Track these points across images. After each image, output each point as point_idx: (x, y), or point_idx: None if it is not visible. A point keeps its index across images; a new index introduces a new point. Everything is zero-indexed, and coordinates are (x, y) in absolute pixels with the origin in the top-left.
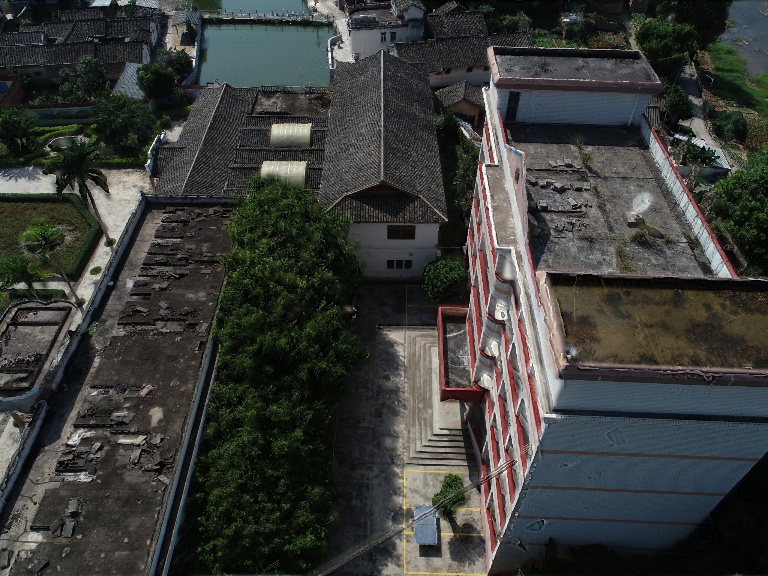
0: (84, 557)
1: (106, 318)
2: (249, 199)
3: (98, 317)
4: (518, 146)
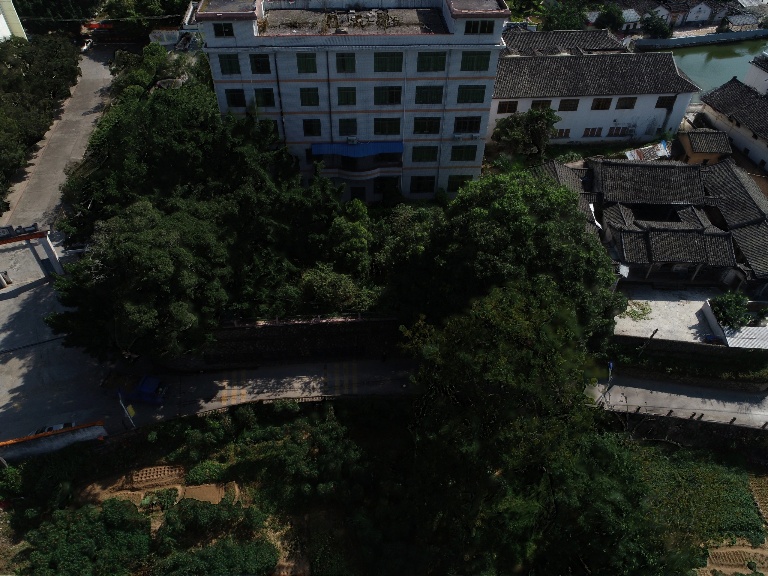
0: None
1: None
2: None
3: None
4: (412, 10)
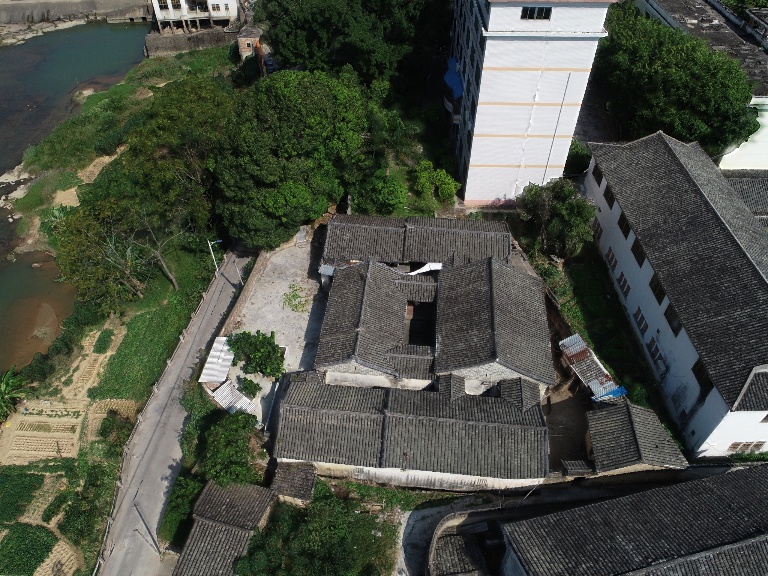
0: (676, 3)
1: (761, 52)
2: (746, 84)
3: (765, 51)
4: None
